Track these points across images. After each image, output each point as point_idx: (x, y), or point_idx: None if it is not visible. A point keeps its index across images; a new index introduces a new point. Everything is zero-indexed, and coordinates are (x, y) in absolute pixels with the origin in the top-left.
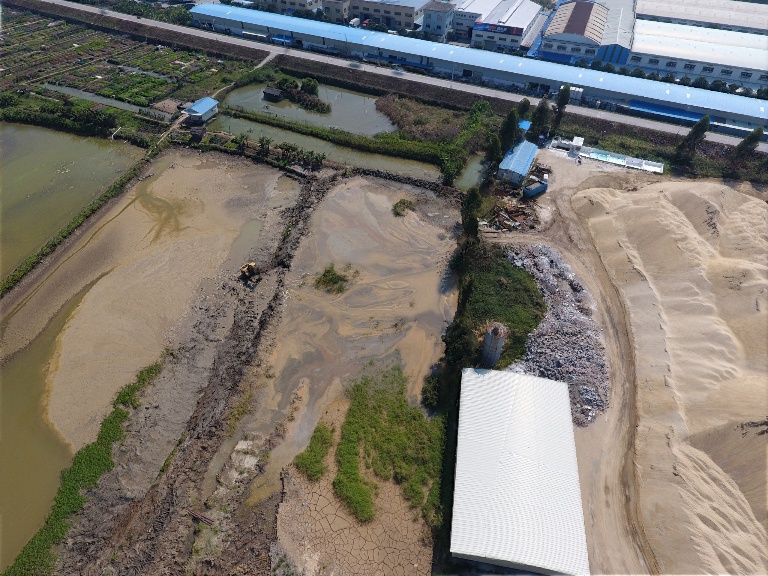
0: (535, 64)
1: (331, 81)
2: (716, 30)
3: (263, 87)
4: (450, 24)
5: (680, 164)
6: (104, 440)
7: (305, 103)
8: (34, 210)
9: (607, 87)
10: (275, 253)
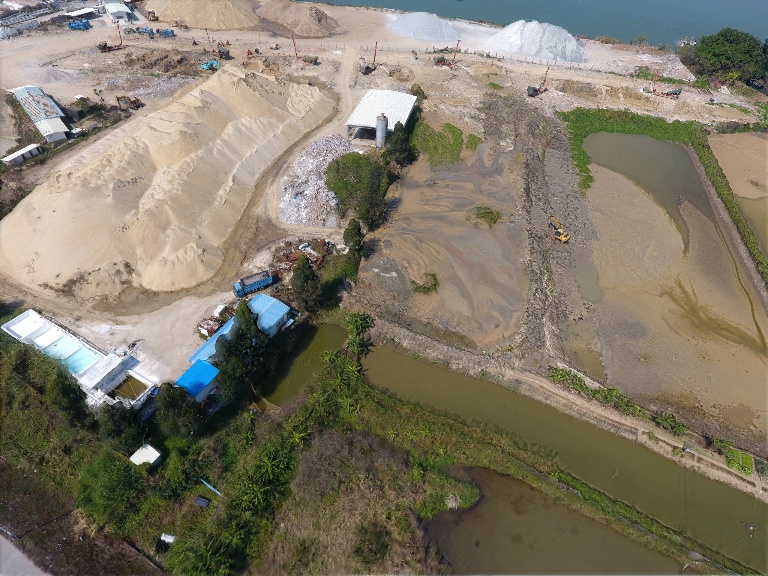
0: None
1: None
2: None
3: None
4: None
5: None
6: (582, 164)
7: None
8: None
9: None
10: None
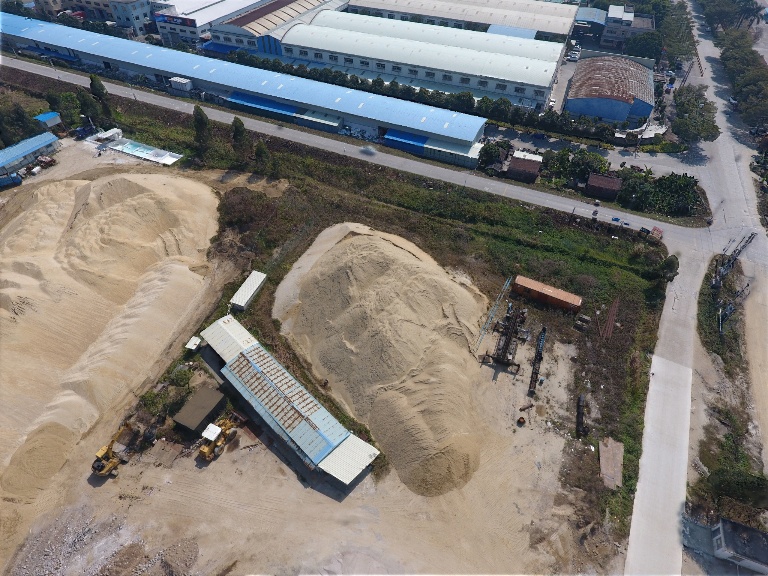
0: (165, 55)
1: None
2: (397, 21)
3: None
4: (147, 16)
5: (198, 156)
6: None
7: None
8: None
9: (211, 78)
10: None
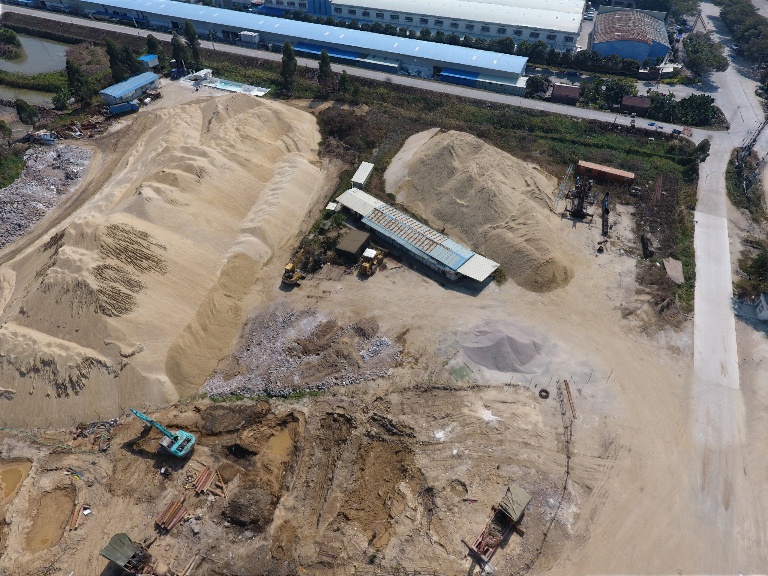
0: (230, 14)
1: (43, 34)
2: None
3: None
4: None
5: None
6: None
7: None
8: None
9: (277, 31)
10: None
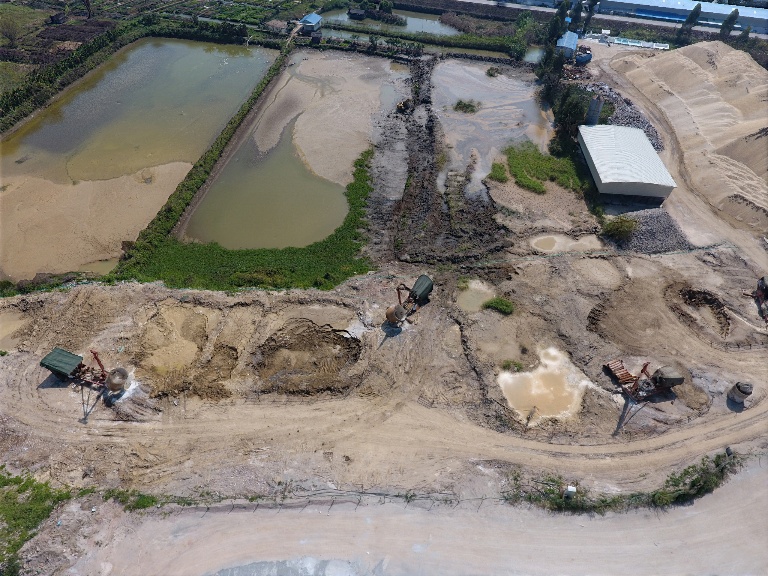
0: None
1: (398, 6)
2: None
3: (341, 13)
4: None
5: (680, 44)
6: (360, 180)
7: (385, 19)
8: (221, 84)
9: None
10: (415, 98)
